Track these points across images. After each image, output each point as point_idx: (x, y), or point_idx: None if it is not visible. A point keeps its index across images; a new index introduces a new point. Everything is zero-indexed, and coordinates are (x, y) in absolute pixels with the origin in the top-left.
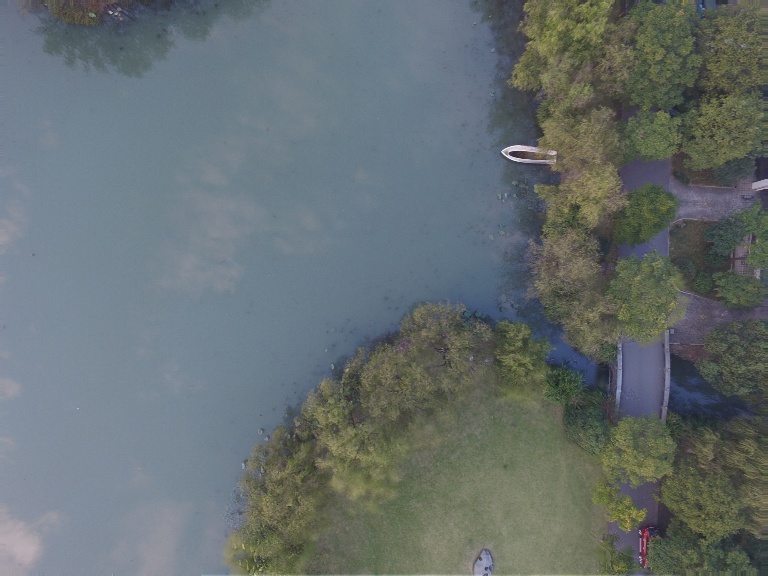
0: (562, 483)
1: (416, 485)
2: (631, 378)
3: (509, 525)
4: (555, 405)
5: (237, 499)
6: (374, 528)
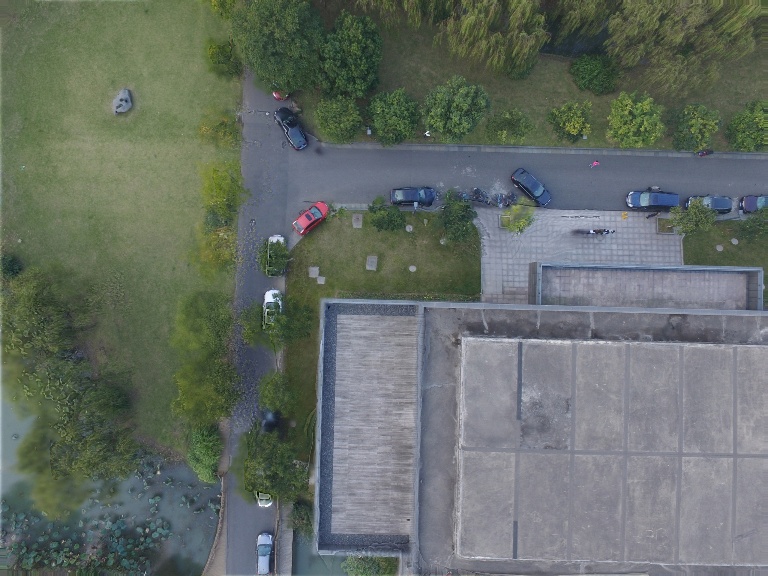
0: (200, 25)
1: (63, 31)
2: None
3: (150, 66)
4: None
5: None
6: (25, 76)
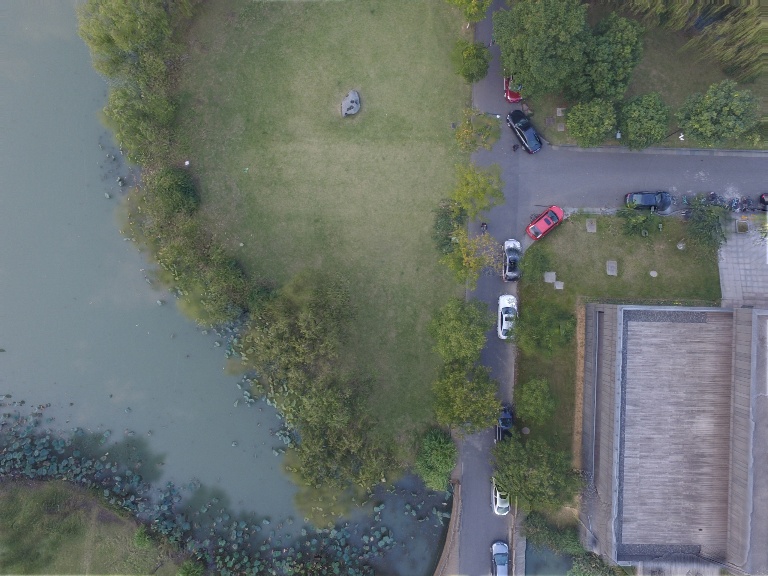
0: (428, 26)
1: (286, 32)
2: None
3: (376, 68)
4: None
5: (115, 56)
6: (246, 76)
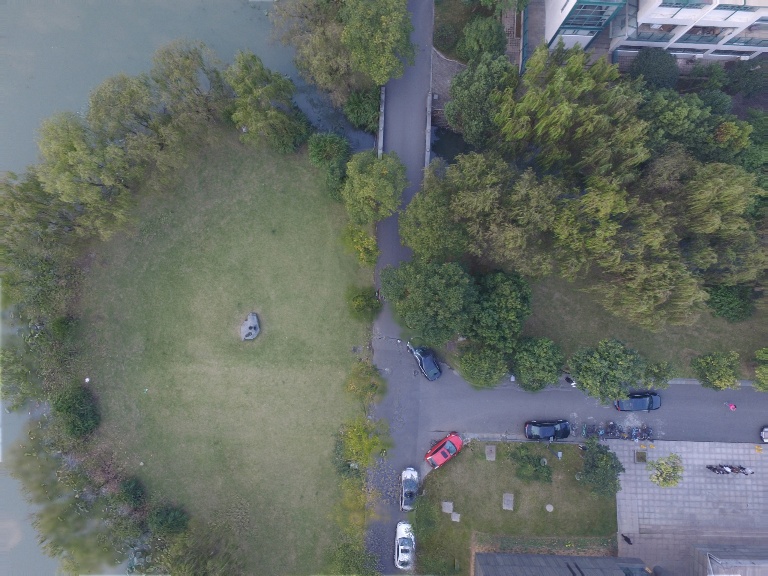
0: (329, 247)
1: (186, 250)
2: (394, 141)
3: (277, 289)
4: (322, 170)
5: (15, 269)
6: (146, 294)
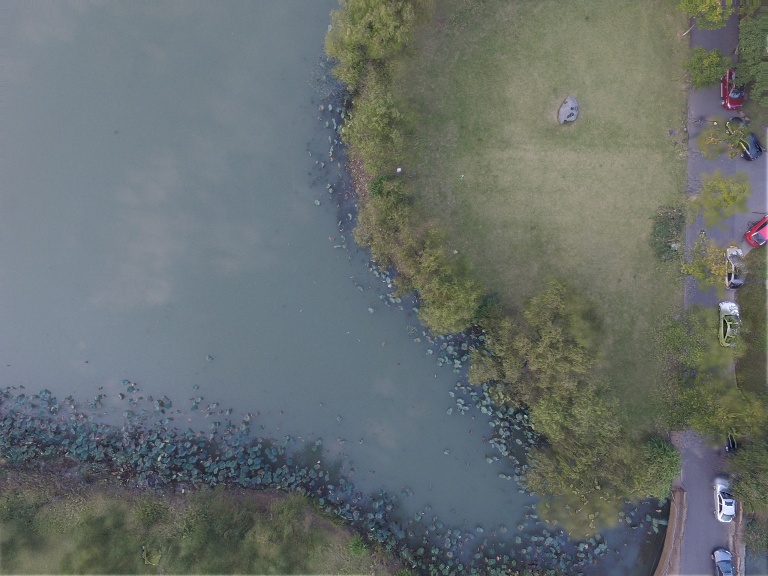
0: (643, 33)
1: (500, 38)
2: None
3: (592, 74)
4: None
5: (324, 62)
6: (459, 83)
